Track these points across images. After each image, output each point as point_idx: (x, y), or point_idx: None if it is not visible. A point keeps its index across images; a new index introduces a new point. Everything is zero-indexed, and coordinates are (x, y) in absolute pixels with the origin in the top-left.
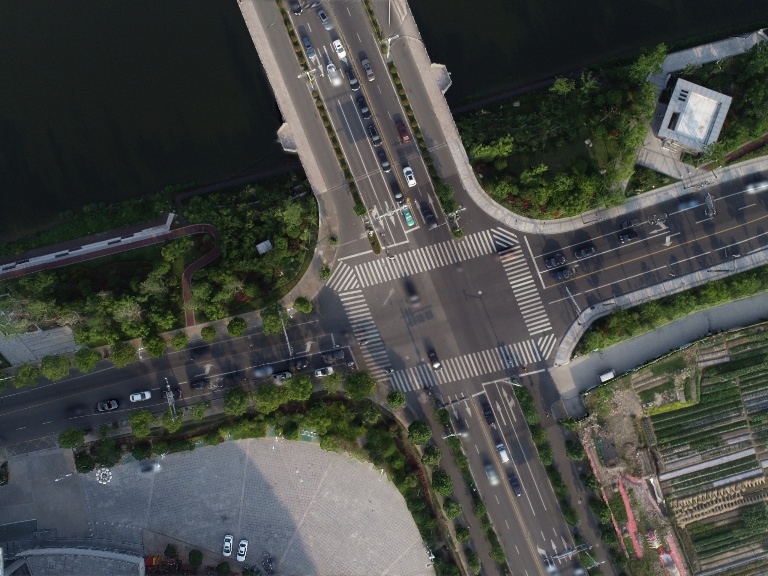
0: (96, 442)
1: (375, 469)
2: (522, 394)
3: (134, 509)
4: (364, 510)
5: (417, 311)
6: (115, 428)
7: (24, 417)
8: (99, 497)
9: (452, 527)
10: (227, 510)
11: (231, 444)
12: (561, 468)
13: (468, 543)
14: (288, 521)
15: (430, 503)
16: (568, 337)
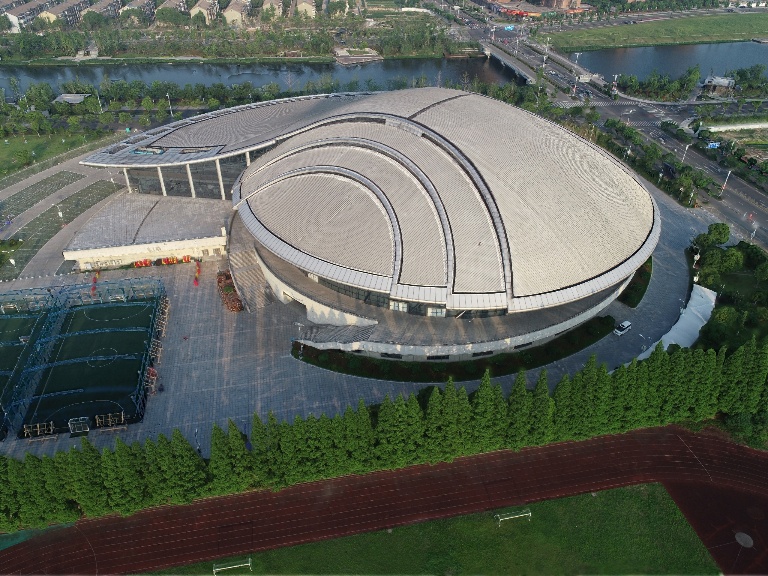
0: None
1: (588, 129)
2: None
3: None
4: None
5: (600, 112)
6: None
7: None
8: None
9: None
10: None
11: None
12: None
13: None
14: None
15: None
16: (684, 122)
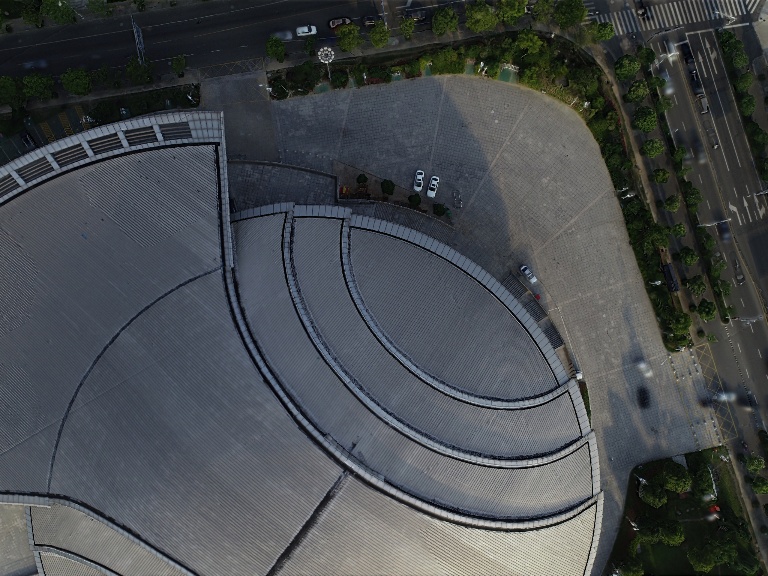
0: (292, 68)
1: (579, 100)
2: (731, 36)
3: (325, 139)
4: (557, 155)
5: None
6: (312, 55)
7: (220, 39)
8: (291, 125)
9: (645, 177)
10: (419, 146)
11: (428, 80)
12: (759, 124)
13: (660, 195)
14: (480, 161)
15: (625, 150)
16: None
